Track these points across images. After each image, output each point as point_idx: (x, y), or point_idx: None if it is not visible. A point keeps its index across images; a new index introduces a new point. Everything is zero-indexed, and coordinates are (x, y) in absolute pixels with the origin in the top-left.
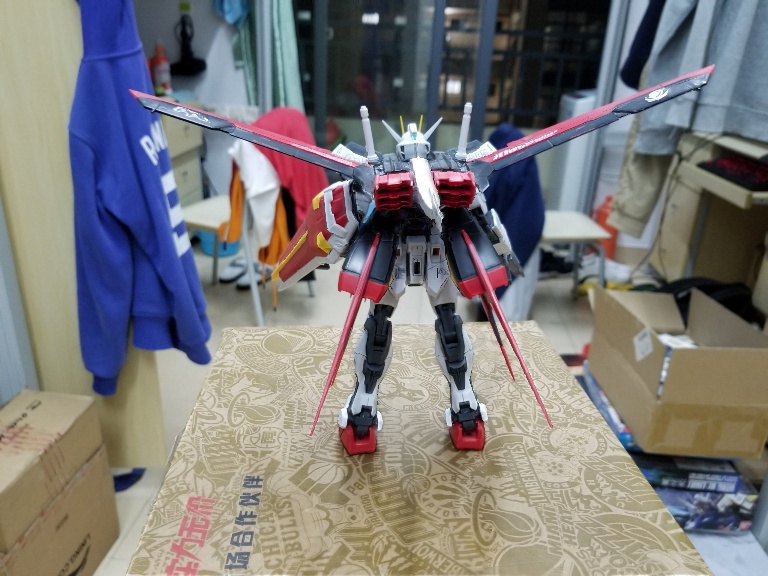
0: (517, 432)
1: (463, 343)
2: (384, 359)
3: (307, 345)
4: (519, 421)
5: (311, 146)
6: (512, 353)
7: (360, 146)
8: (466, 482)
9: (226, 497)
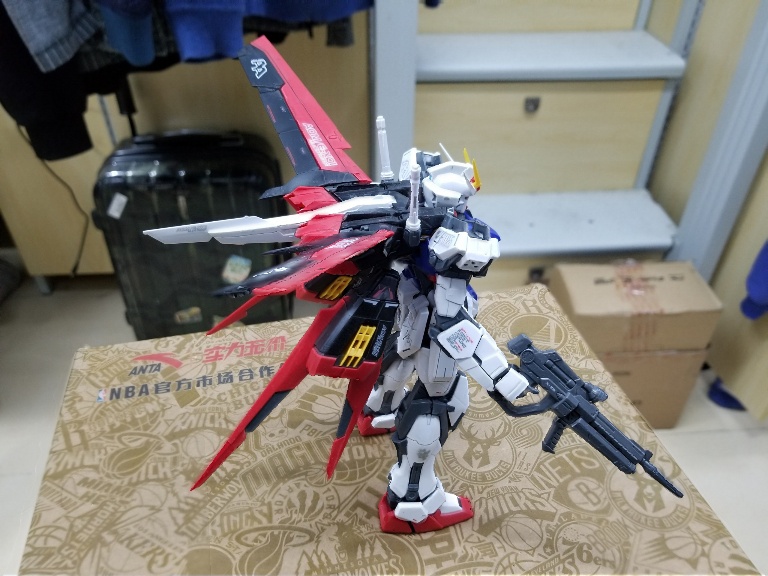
0: (425, 570)
1: (407, 426)
2: (382, 372)
3: (539, 348)
4: (450, 573)
5: (331, 132)
6: (634, 567)
7: (424, 158)
8: (326, 518)
9: (287, 354)
